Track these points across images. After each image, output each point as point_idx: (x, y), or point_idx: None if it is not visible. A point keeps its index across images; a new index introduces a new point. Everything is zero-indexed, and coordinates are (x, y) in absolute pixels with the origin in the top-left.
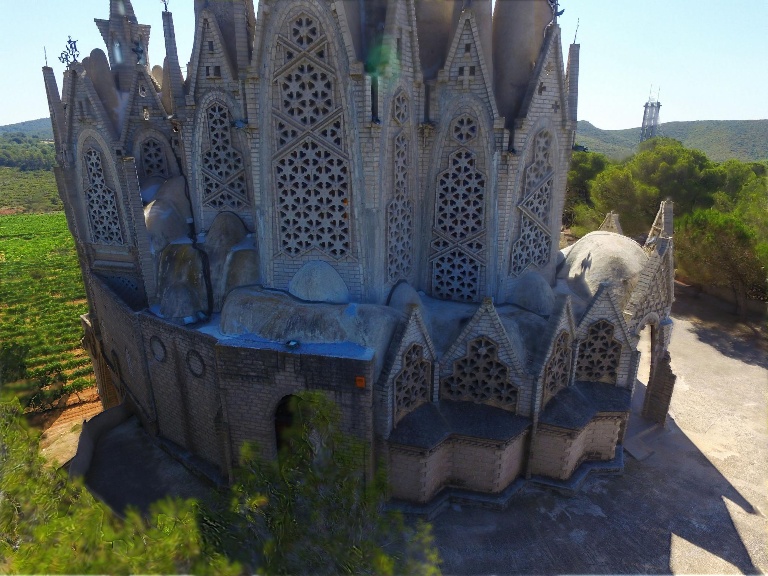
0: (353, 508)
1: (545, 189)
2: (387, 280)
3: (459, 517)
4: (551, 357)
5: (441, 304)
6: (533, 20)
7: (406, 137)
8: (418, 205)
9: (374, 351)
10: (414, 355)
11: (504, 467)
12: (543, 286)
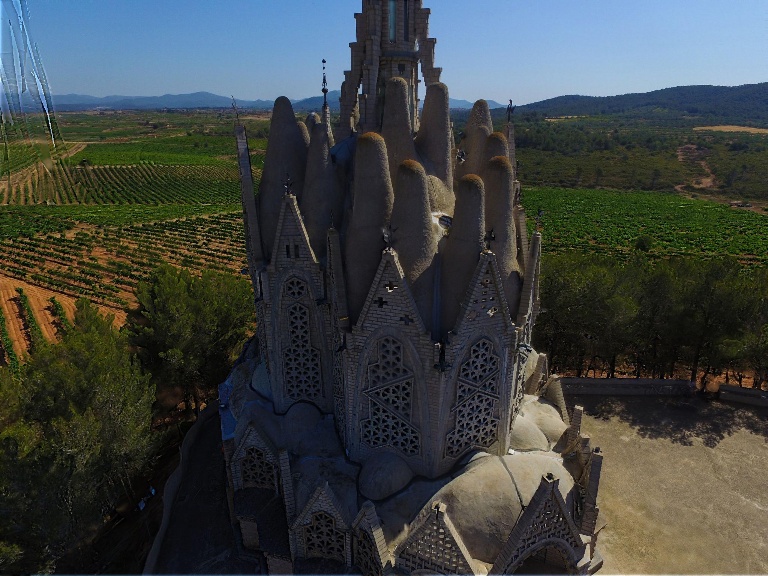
0: (2, 476)
1: (403, 388)
2: (285, 397)
3: (249, 573)
4: (309, 524)
5: (325, 433)
6: (406, 234)
7: (304, 307)
8: (328, 353)
9: (234, 436)
10: (254, 454)
11: (275, 570)
12: (378, 470)
